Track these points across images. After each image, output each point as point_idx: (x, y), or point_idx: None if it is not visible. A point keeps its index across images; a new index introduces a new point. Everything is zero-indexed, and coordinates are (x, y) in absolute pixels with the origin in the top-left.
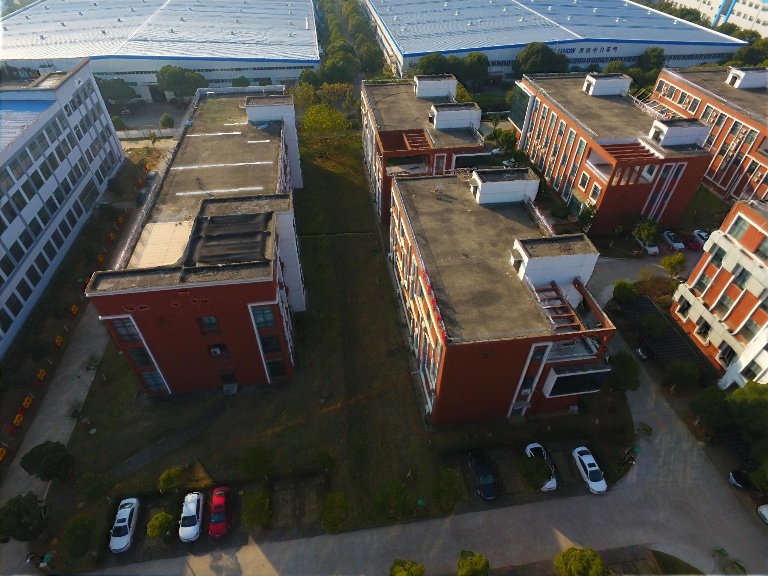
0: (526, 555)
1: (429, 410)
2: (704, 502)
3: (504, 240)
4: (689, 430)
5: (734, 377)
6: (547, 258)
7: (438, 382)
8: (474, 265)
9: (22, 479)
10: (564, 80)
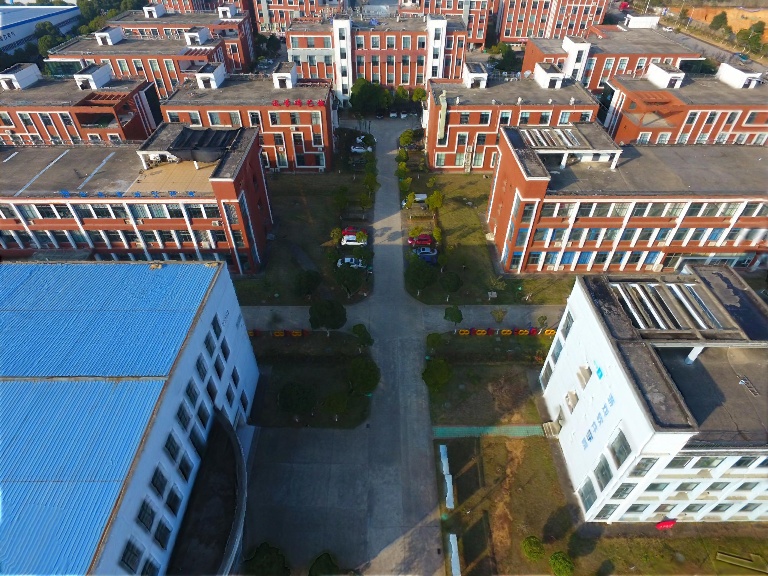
0: (395, 161)
1: (323, 168)
2: (385, 125)
3: (257, 88)
4: (357, 120)
5: (342, 98)
6: (292, 70)
7: (325, 137)
8: (272, 96)
9: (303, 321)
10: (73, 46)
